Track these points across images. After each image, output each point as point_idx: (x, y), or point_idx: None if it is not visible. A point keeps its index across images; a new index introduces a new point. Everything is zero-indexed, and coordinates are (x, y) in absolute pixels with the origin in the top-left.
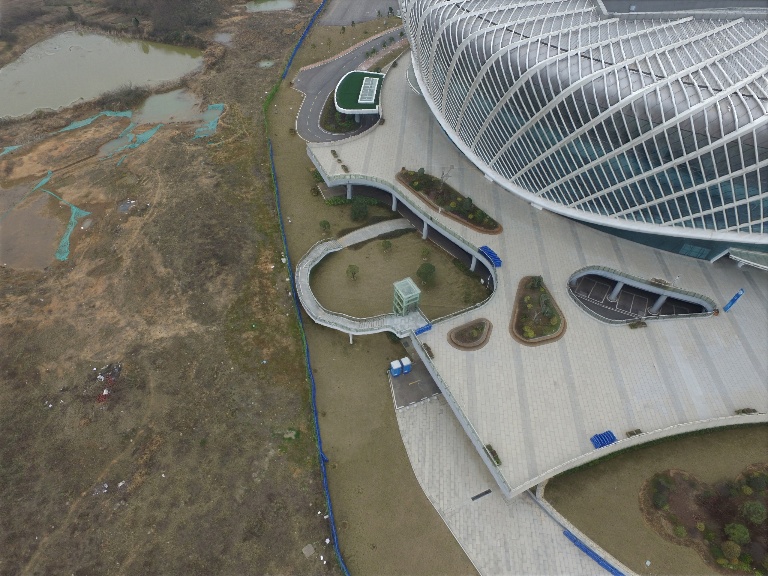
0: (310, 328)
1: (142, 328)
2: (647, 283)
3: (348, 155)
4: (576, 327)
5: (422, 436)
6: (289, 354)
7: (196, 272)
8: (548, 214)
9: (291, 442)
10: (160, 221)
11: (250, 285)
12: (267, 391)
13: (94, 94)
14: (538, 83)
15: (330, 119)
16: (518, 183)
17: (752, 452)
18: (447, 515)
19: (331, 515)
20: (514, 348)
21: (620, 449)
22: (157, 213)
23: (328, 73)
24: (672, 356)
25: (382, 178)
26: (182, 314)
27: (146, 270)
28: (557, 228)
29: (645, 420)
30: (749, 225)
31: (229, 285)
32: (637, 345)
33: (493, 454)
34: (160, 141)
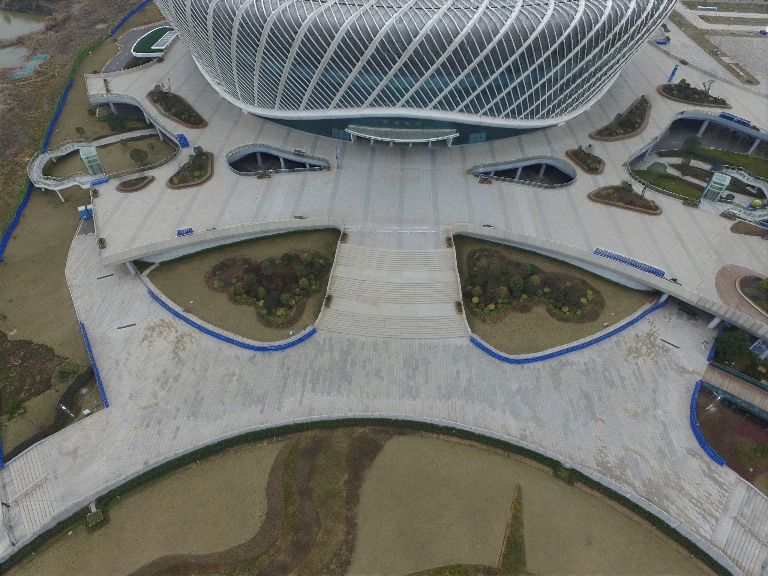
0: (37, 194)
1: None
2: (291, 154)
3: (117, 82)
4: (218, 179)
5: (84, 250)
6: (9, 207)
7: None
8: (251, 116)
9: None
10: None
11: (2, 169)
12: None
13: None
14: (176, 0)
15: (132, 64)
16: (230, 94)
17: (300, 244)
18: (74, 287)
19: None
20: (162, 191)
21: (212, 247)
22: None
23: None
24: (275, 193)
25: (134, 96)
26: None
27: None
28: (251, 124)
29: (226, 225)
30: (336, 101)
31: None
32: (254, 187)
33: (100, 241)
34: None
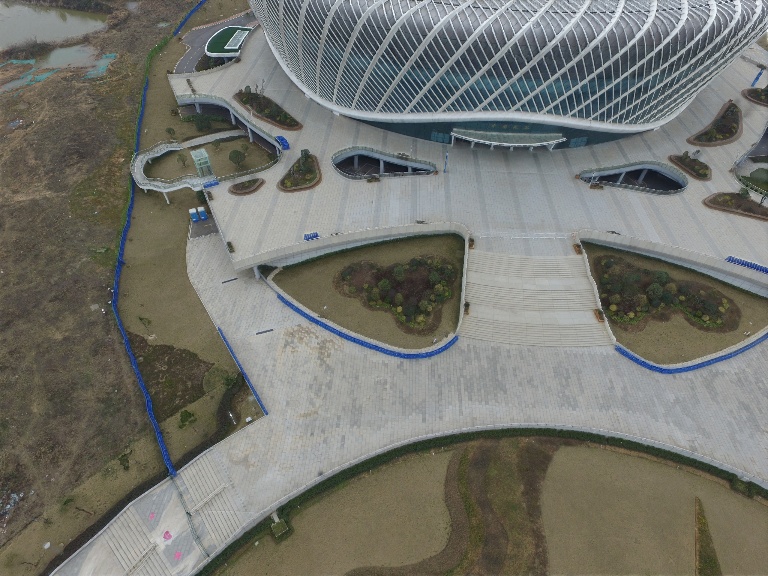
0: (140, 195)
1: (8, 195)
2: (394, 157)
3: (200, 83)
4: (327, 182)
5: (201, 253)
6: (117, 209)
7: (59, 162)
8: (343, 118)
9: (101, 254)
10: (39, 132)
11: (100, 170)
12: (92, 228)
13: (3, 46)
14: (289, 1)
15: (204, 64)
16: (322, 96)
17: (423, 249)
18: (201, 290)
19: (115, 288)
20: (275, 194)
21: (333, 251)
22: (38, 127)
23: (216, 31)
24: (389, 197)
25: None
26: (41, 187)
27: (20, 162)
28: (345, 126)
29: (348, 229)
30: (448, 104)
31: (83, 170)
32: (367, 191)
33: (229, 245)
34: (54, 80)
